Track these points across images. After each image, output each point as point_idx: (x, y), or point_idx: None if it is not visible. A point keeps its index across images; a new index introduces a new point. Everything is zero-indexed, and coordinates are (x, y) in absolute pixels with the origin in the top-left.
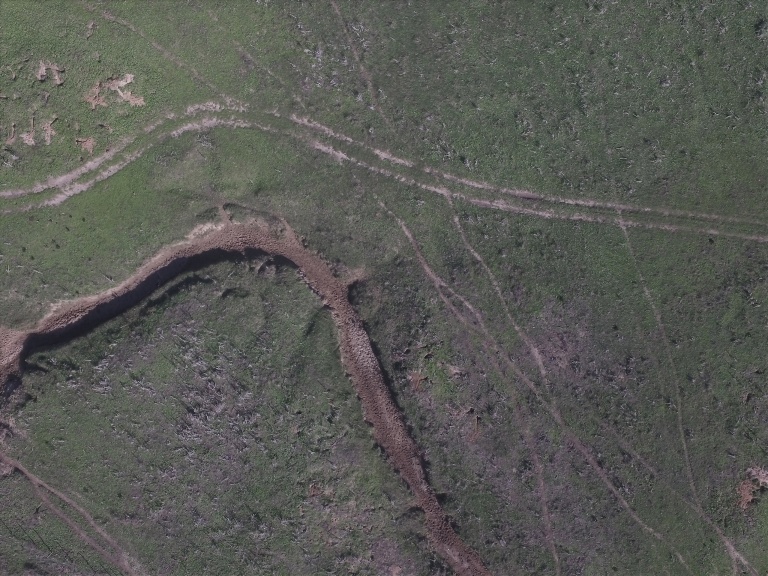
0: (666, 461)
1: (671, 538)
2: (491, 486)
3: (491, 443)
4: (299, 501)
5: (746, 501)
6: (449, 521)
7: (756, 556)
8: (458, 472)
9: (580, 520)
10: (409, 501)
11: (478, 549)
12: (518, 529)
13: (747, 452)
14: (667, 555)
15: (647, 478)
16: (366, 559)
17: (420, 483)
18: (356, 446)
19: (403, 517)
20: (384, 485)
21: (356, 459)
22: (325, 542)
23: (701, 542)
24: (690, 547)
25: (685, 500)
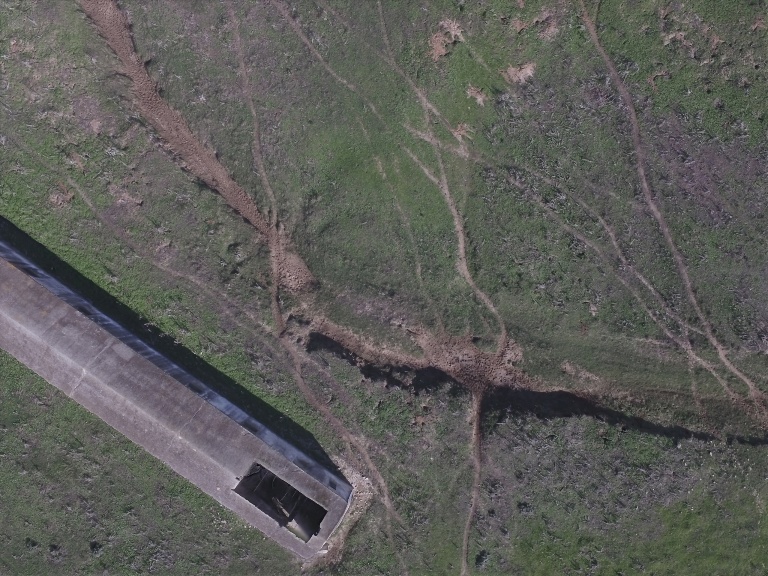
0: (361, 17)
1: (364, 89)
2: (190, 44)
3: (189, 1)
4: (1, 58)
5: (438, 54)
6: (157, 90)
7: (448, 108)
8: (158, 32)
9: (276, 74)
10: (114, 66)
11: (180, 109)
12: (217, 86)
13: (439, 7)
14: (360, 106)
15: (341, 32)
16: (67, 114)
17: (130, 56)
18: (57, 6)
19: (107, 79)
20: (87, 46)
21: (56, 17)
22: (27, 99)
23: (393, 92)
24: (382, 98)
25: (378, 54)
